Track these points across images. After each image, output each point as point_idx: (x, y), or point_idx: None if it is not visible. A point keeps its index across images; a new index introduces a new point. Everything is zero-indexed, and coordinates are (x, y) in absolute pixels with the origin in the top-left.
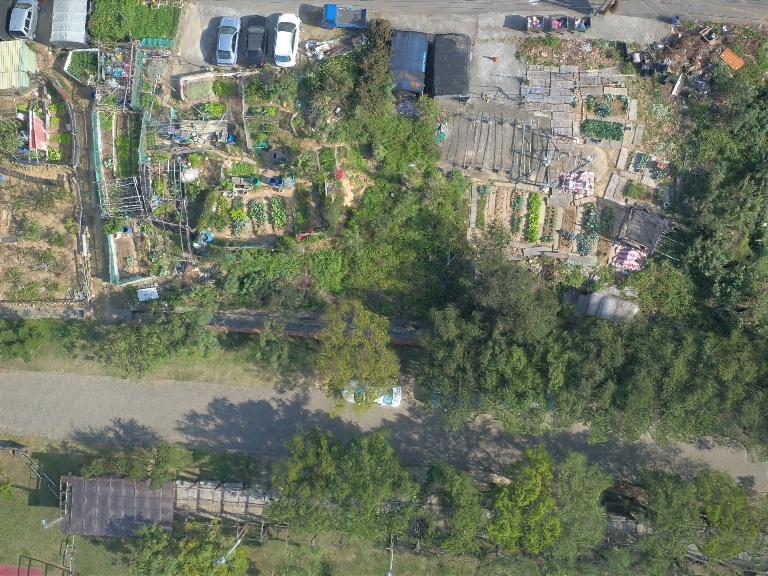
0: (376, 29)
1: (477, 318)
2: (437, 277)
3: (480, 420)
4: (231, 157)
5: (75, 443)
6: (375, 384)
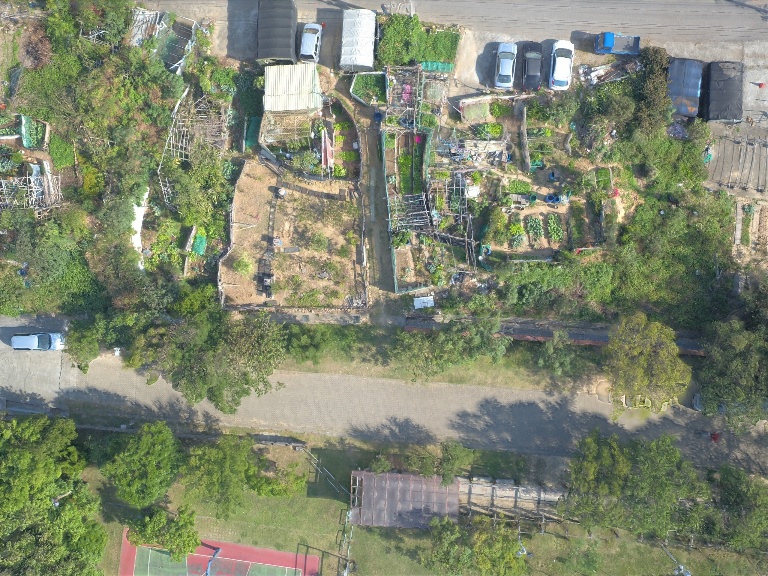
0: (654, 56)
1: (763, 330)
2: (703, 290)
3: (741, 424)
4: (507, 175)
5: (353, 440)
6: (667, 391)
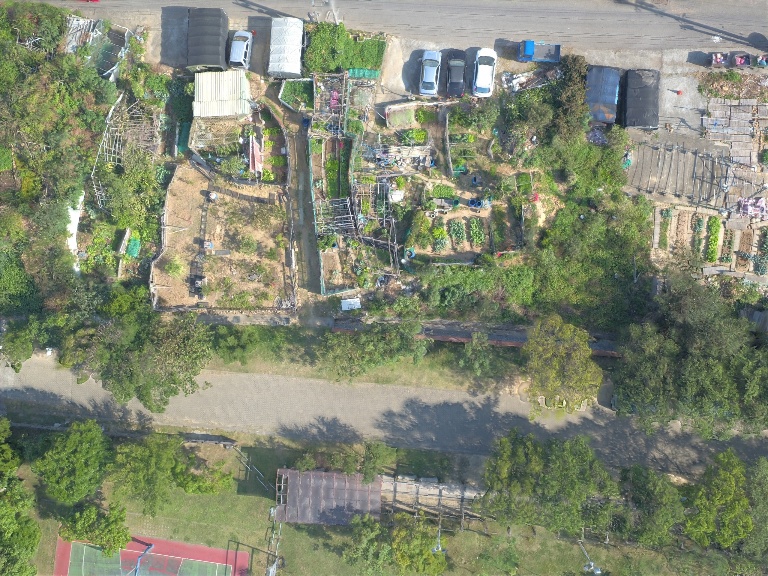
0: (572, 64)
1: (673, 333)
2: (622, 293)
3: (659, 425)
4: (431, 180)
5: (282, 439)
6: (579, 391)
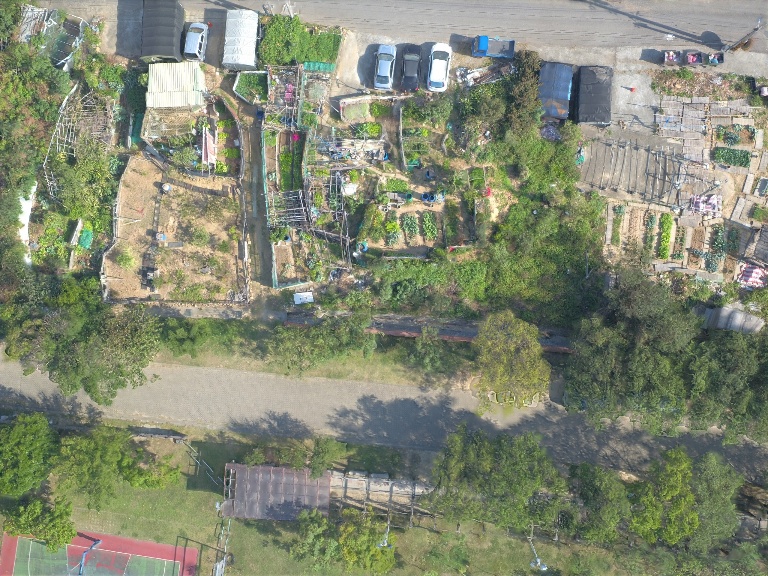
0: (526, 60)
1: (622, 328)
2: (574, 289)
3: (611, 422)
4: (385, 174)
5: (232, 433)
6: (527, 386)
